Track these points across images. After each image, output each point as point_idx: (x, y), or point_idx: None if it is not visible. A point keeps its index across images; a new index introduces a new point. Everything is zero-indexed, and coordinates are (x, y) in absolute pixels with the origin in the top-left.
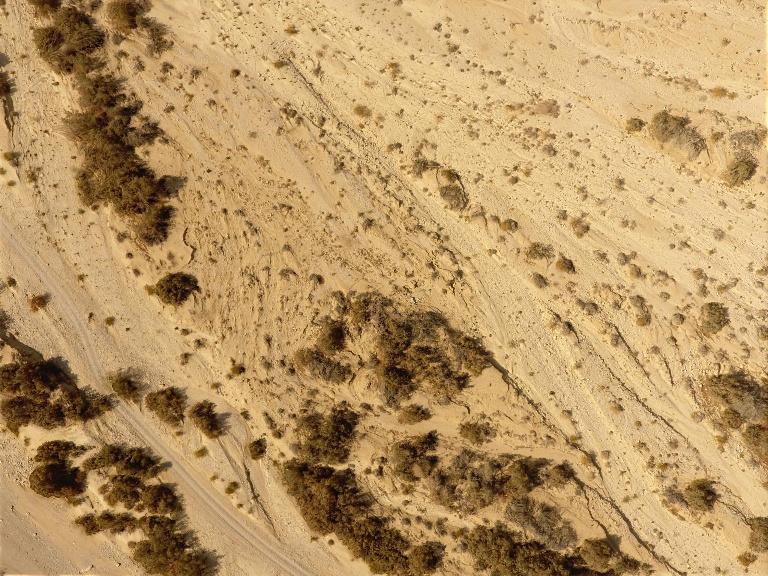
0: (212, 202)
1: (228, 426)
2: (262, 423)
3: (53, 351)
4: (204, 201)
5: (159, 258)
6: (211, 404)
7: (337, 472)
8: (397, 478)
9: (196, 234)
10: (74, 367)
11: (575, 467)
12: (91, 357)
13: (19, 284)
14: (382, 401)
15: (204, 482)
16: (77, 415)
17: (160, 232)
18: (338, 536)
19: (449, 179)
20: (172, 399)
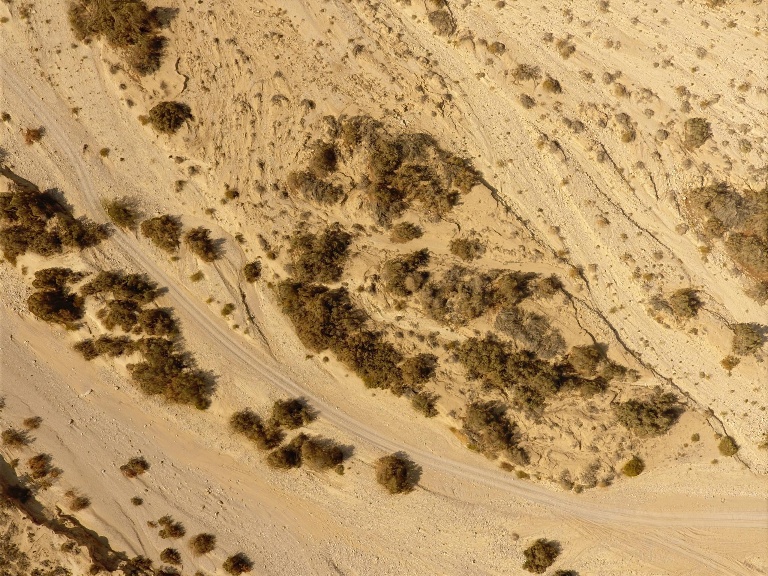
0: (204, 32)
1: (223, 251)
2: (256, 246)
3: (49, 183)
4: (196, 31)
5: (152, 88)
6: (206, 230)
7: (331, 291)
8: (390, 294)
9: (188, 63)
10: (70, 198)
11: (563, 280)
12: (86, 188)
13: (13, 119)
14: (374, 220)
15: (200, 305)
16: (74, 240)
17: (153, 60)
18: (332, 348)
19: (437, 4)
20: (167, 224)
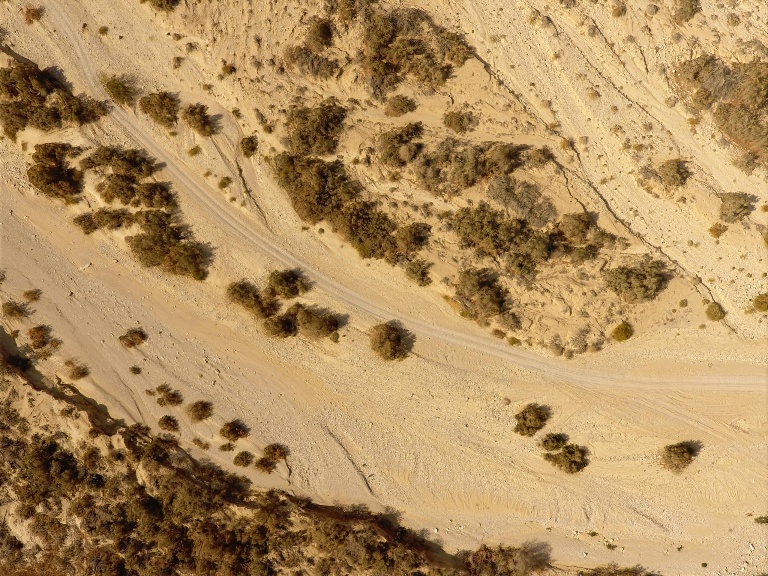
0: None
1: (220, 126)
2: (253, 120)
3: (48, 61)
4: None
5: None
6: (203, 106)
7: (326, 164)
8: (384, 166)
9: None
10: (69, 75)
11: (555, 152)
12: (85, 65)
13: None
14: (369, 94)
15: (198, 180)
16: (73, 113)
17: None
18: (328, 217)
19: None
20: (165, 99)
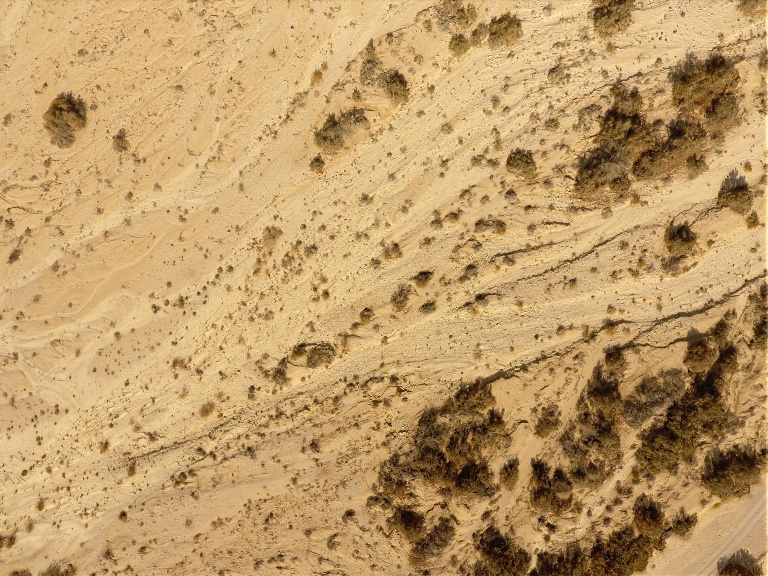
0: None
1: None
2: None
3: None
4: None
5: None
6: None
7: (537, 567)
8: (563, 513)
9: None
10: None
11: (613, 343)
12: None
13: None
14: (486, 500)
15: None
16: None
17: None
18: None
19: (301, 355)
20: None
